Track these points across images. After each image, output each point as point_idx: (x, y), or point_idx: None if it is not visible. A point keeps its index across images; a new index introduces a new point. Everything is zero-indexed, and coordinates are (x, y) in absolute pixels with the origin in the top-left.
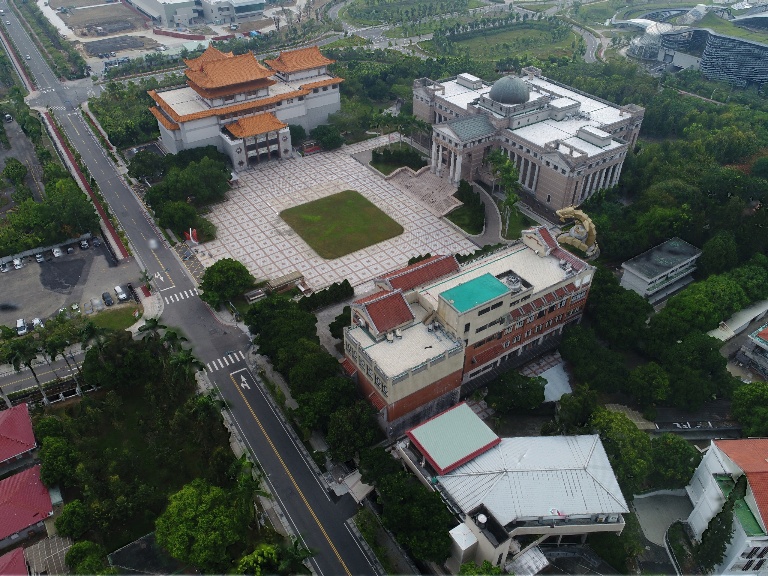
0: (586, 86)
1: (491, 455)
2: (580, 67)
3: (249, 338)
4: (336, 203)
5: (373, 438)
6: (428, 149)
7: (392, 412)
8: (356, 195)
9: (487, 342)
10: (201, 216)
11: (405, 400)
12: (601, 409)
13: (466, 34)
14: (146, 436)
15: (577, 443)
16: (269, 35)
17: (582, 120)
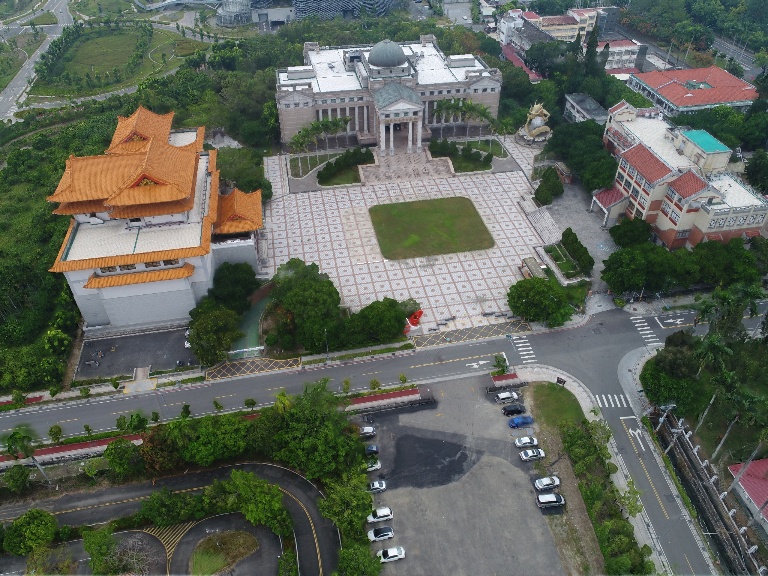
0: None
1: None
2: (270, 40)
3: (613, 309)
4: (392, 221)
5: None
6: (320, 151)
7: None
8: (384, 207)
9: None
10: None
11: None
12: None
13: (56, 65)
14: (746, 389)
15: None
16: None
17: (422, 59)
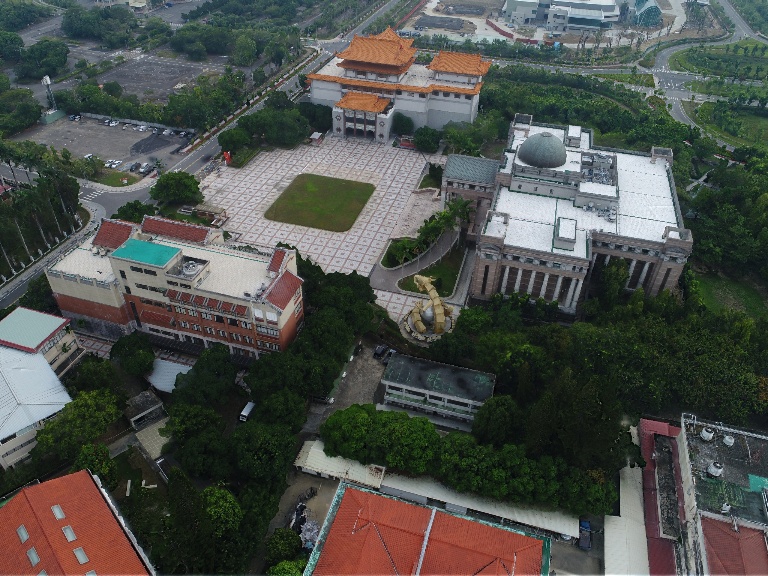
0: (759, 206)
1: (16, 354)
2: None
3: None
4: (345, 187)
5: (43, 310)
6: None
7: (59, 301)
8: (369, 190)
9: (156, 305)
10: (261, 151)
11: (68, 298)
12: (106, 393)
13: None
14: None
15: (54, 393)
16: (557, 48)
17: (603, 218)
